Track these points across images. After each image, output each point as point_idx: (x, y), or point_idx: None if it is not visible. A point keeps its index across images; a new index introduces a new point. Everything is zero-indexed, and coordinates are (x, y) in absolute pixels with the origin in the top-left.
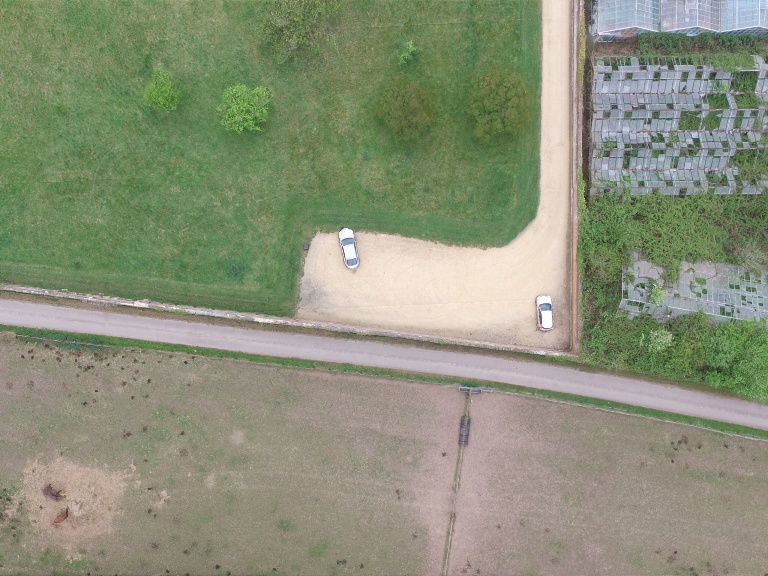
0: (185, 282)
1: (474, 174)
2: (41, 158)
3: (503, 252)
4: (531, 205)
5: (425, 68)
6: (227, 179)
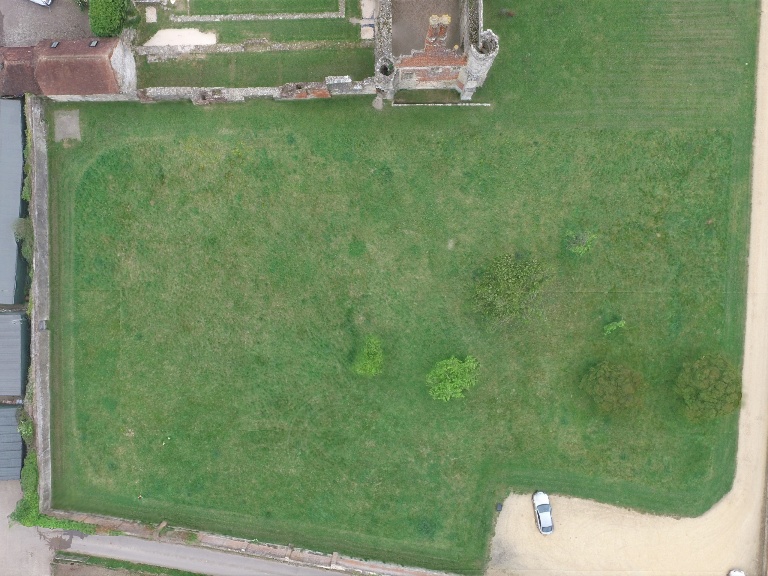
0: (375, 536)
1: (671, 443)
2: (238, 406)
3: (696, 522)
4: (727, 477)
5: (627, 335)
6: (423, 436)
